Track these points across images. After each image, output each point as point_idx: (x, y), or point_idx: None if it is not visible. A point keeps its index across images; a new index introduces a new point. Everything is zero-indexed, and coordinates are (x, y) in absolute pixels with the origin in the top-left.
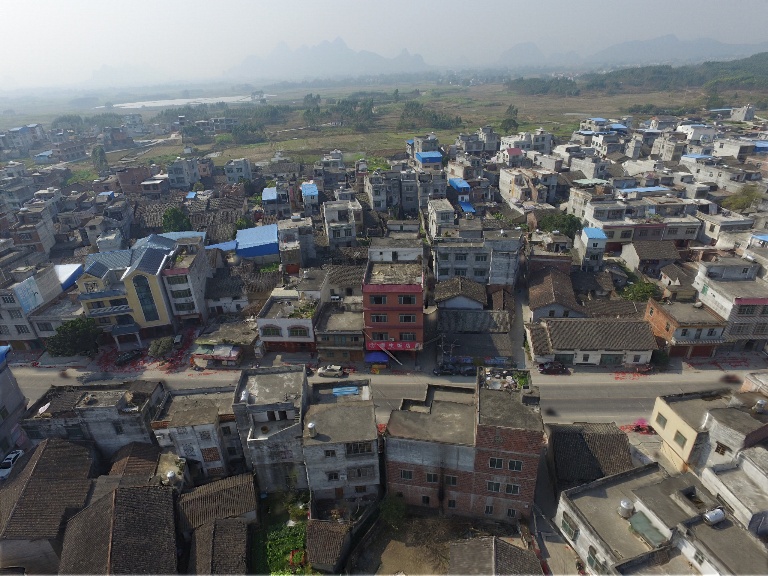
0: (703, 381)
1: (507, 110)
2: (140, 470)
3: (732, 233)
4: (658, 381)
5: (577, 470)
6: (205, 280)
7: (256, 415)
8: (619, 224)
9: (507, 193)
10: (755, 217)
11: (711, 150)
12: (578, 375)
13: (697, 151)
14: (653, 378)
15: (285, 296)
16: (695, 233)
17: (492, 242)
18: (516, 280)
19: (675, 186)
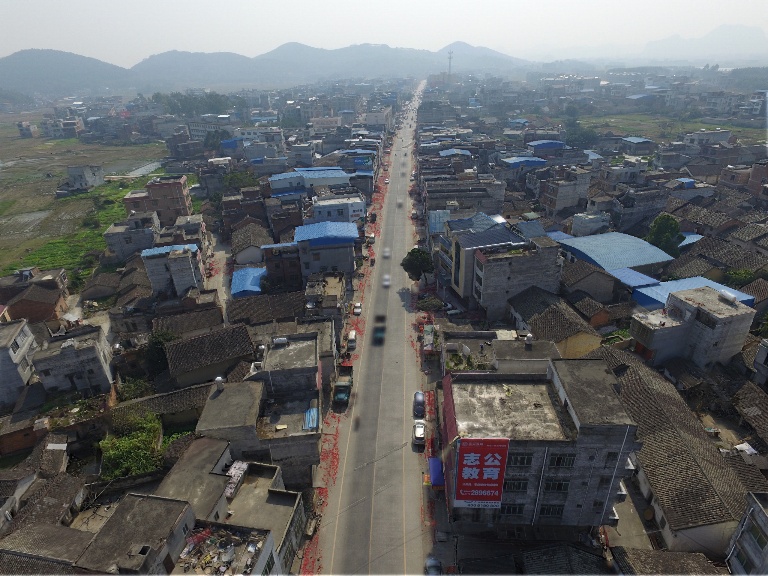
0: None
1: None
2: None
3: None
4: None
5: None
6: (528, 286)
7: None
8: None
9: None
10: None
11: None
12: None
13: None
14: None
15: None
16: None
17: None
18: None
19: None
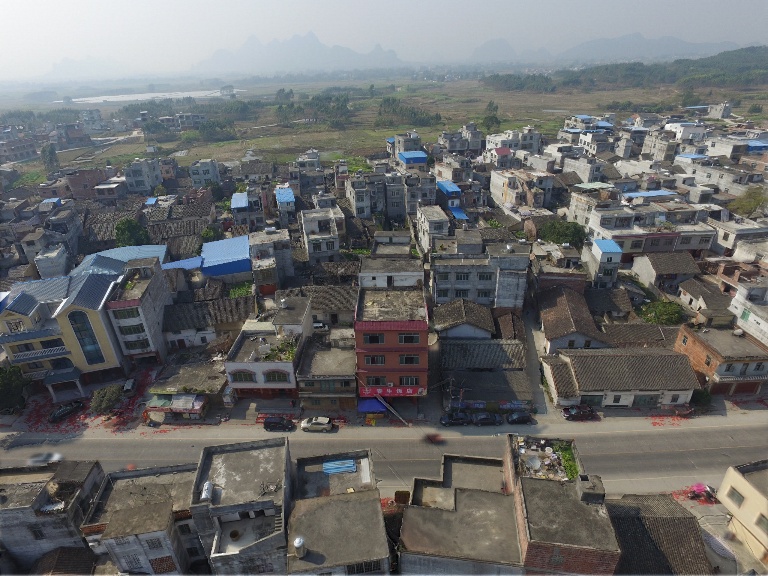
0: (753, 425)
1: (487, 107)
2: None
3: (752, 243)
4: (702, 426)
5: (640, 570)
6: (163, 309)
7: (223, 515)
8: (629, 233)
9: (499, 197)
10: (764, 222)
11: (705, 149)
12: (610, 421)
13: (690, 150)
14: (696, 423)
15: (259, 330)
16: (709, 242)
17: (498, 259)
18: None
19: (678, 189)
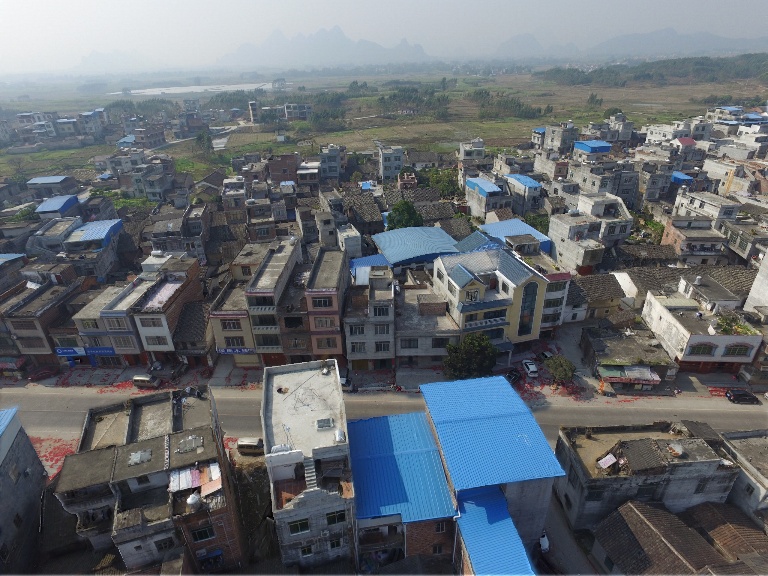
0: None
1: (589, 99)
2: (762, 543)
3: None
4: None
5: None
6: None
7: None
8: None
9: None
10: None
11: None
12: None
13: None
14: None
15: (680, 306)
16: None
17: None
18: None
19: None
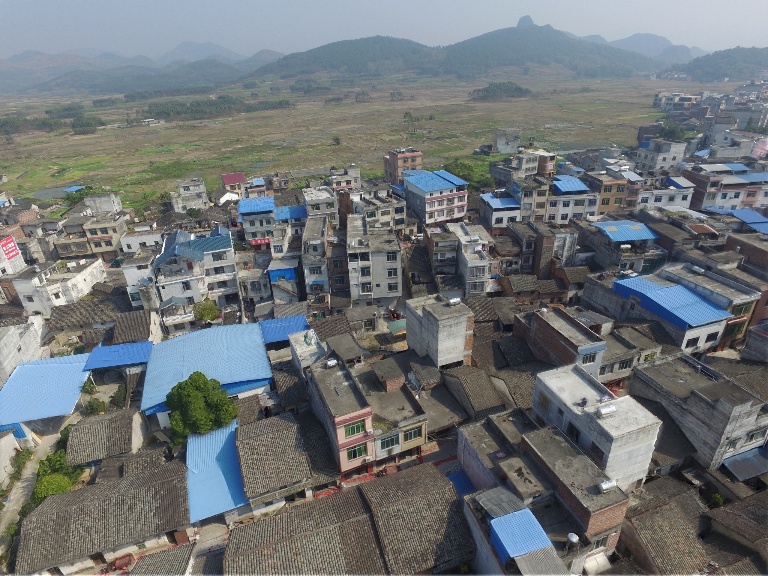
0: None
1: None
2: None
3: None
4: None
5: None
6: None
7: None
8: None
9: None
10: None
11: None
12: None
13: None
14: None
15: None
16: None
17: None
18: None
19: None
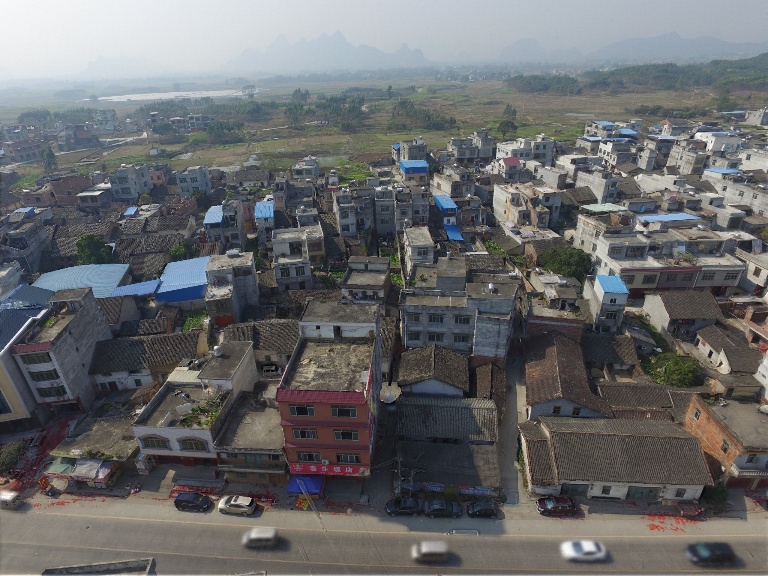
0: None
1: None
2: None
3: None
4: (714, 535)
5: None
6: (93, 347)
7: None
8: (641, 266)
9: (502, 214)
10: None
11: (738, 163)
12: (595, 519)
13: (722, 164)
14: (706, 528)
15: (186, 382)
16: (737, 279)
17: (477, 301)
18: (509, 346)
19: (703, 211)
